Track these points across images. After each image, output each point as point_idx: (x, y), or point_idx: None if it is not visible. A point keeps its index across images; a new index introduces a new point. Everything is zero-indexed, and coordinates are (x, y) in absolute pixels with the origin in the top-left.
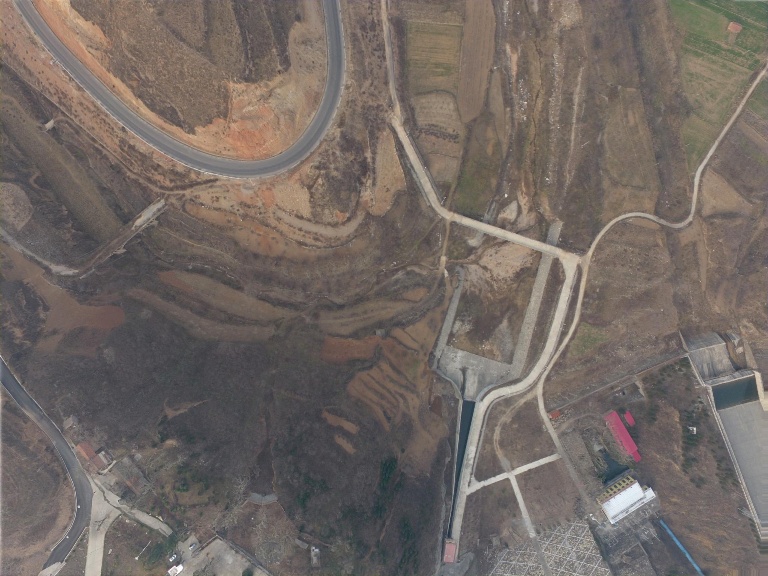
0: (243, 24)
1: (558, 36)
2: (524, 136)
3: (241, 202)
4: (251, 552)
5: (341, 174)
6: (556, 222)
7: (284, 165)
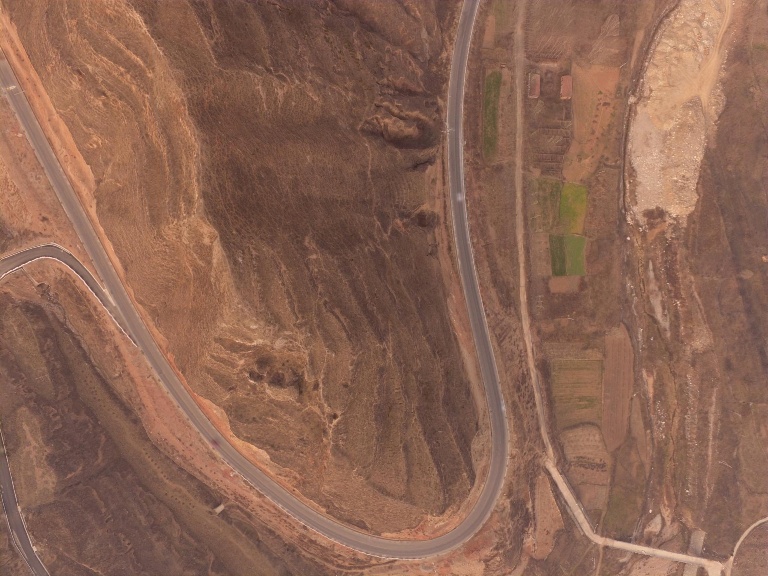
0: (436, 458)
1: (690, 358)
2: (664, 454)
3: (418, 575)
4: None
5: (512, 540)
6: (698, 531)
7: (459, 540)
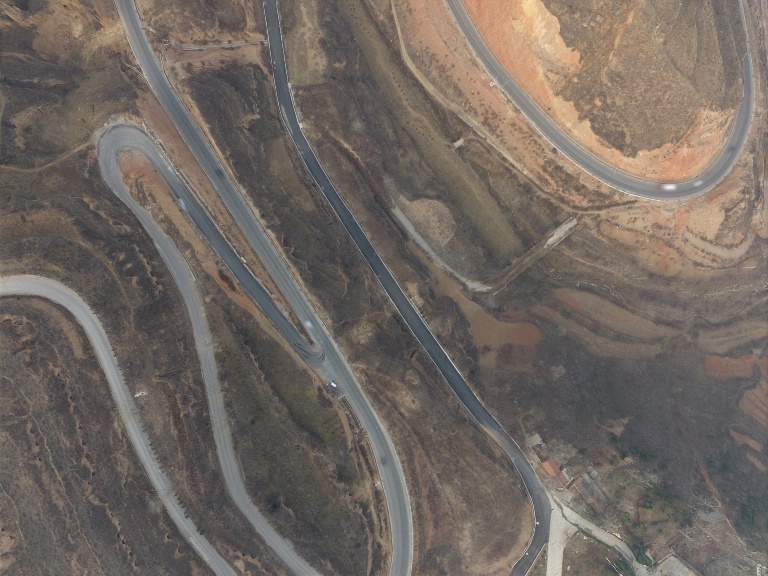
0: None
1: None
2: None
3: (655, 223)
4: (699, 569)
5: None
6: None
7: (700, 188)
